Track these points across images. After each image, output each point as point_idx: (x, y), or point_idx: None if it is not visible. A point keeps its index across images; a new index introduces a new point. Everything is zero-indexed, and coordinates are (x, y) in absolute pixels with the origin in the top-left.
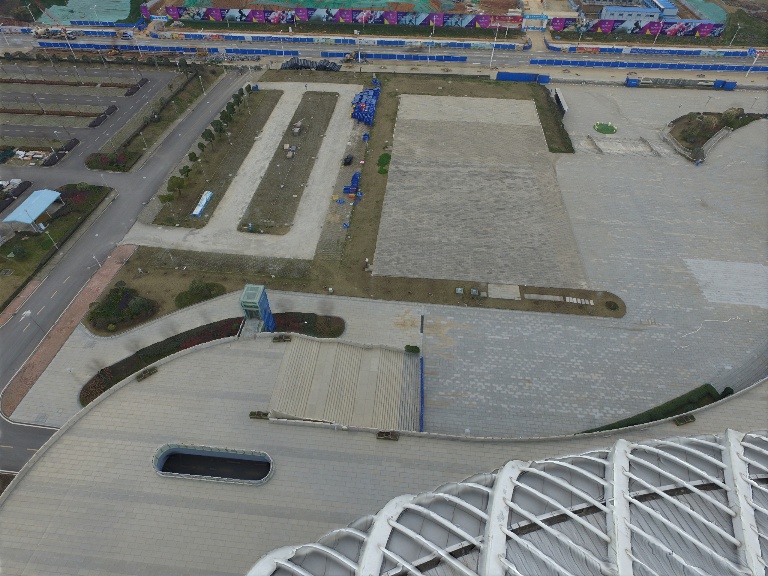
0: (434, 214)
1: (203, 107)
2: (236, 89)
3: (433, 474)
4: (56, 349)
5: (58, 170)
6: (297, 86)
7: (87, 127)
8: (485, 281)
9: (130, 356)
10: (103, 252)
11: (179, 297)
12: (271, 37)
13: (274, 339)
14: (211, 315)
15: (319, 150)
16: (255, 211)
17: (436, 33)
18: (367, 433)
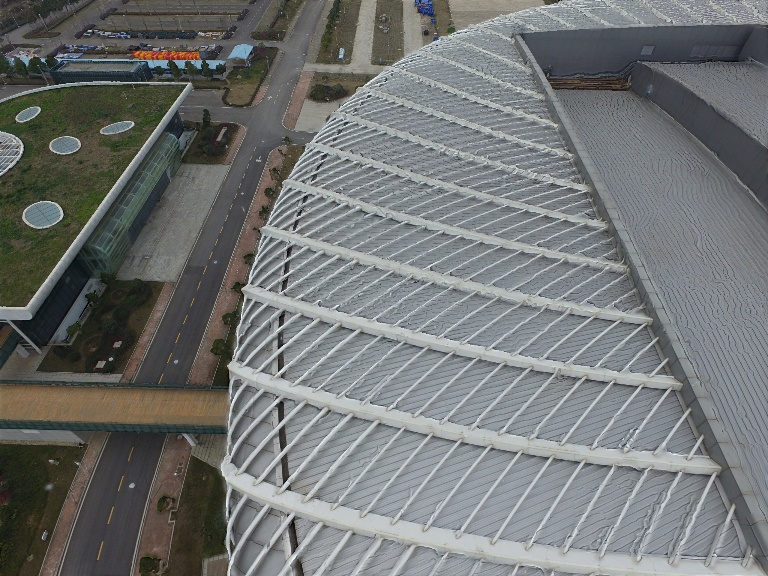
0: None
1: (308, 10)
2: (325, 1)
3: None
4: (299, 108)
5: (234, 41)
6: None
7: (236, 21)
8: None
9: None
10: (295, 74)
11: None
12: None
13: None
14: None
15: (403, 29)
16: (378, 56)
17: None
18: None
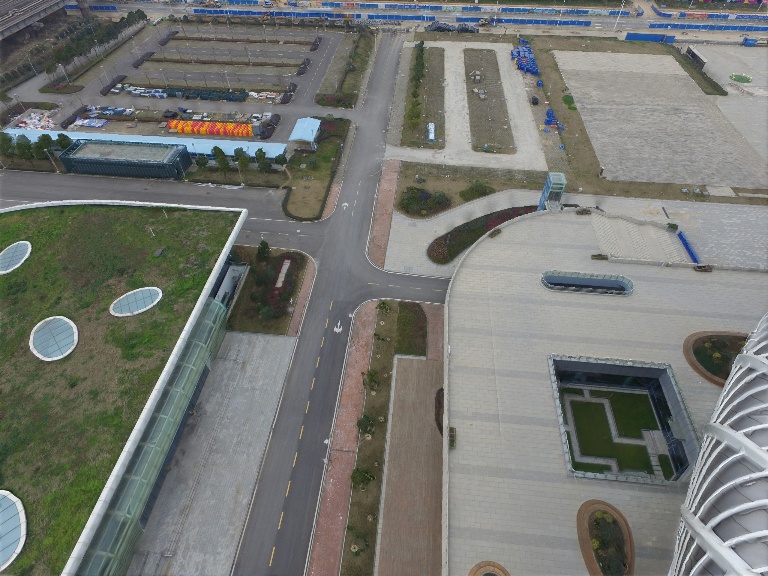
0: (634, 139)
1: (381, 61)
2: (399, 47)
3: (749, 291)
4: (387, 227)
5: (295, 107)
6: (453, 44)
7: (295, 75)
8: (702, 184)
9: (450, 231)
10: (375, 165)
11: (462, 194)
12: (403, 5)
13: (579, 212)
14: (494, 206)
15: (504, 93)
16: (479, 137)
17: (550, 2)
18: (685, 268)
